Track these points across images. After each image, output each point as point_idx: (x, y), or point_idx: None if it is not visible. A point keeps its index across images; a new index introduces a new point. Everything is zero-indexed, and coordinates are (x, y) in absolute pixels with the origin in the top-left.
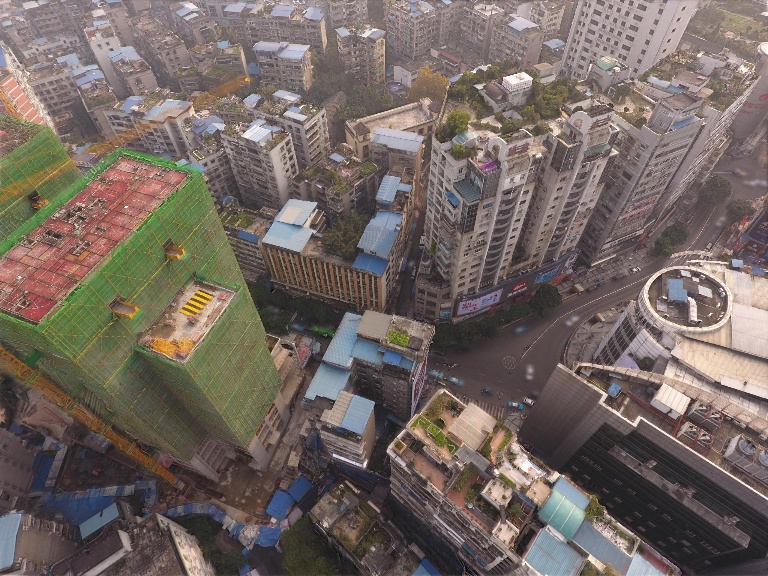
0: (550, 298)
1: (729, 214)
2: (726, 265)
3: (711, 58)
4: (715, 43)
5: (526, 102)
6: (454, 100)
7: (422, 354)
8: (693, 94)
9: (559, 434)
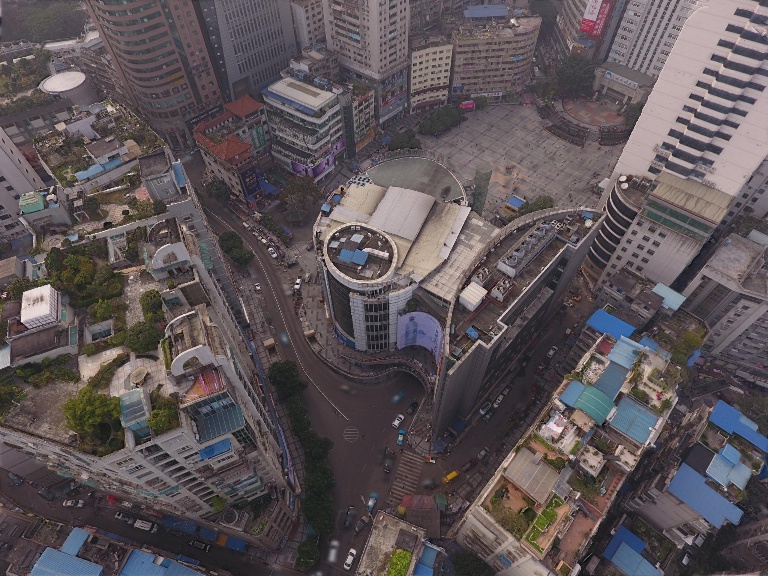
0: (289, 372)
1: (219, 198)
2: (322, 216)
3: (77, 122)
4: (8, 115)
5: (72, 308)
6: (5, 412)
7: (422, 532)
8: (129, 154)
9: (460, 398)
